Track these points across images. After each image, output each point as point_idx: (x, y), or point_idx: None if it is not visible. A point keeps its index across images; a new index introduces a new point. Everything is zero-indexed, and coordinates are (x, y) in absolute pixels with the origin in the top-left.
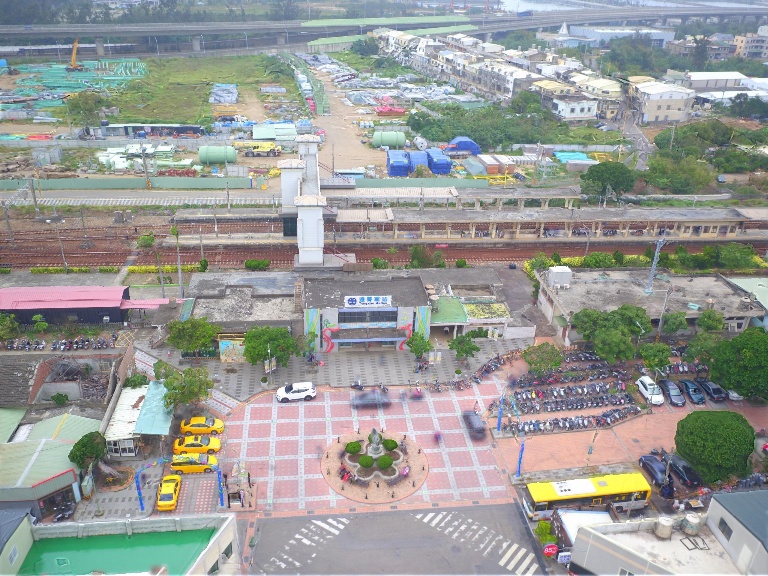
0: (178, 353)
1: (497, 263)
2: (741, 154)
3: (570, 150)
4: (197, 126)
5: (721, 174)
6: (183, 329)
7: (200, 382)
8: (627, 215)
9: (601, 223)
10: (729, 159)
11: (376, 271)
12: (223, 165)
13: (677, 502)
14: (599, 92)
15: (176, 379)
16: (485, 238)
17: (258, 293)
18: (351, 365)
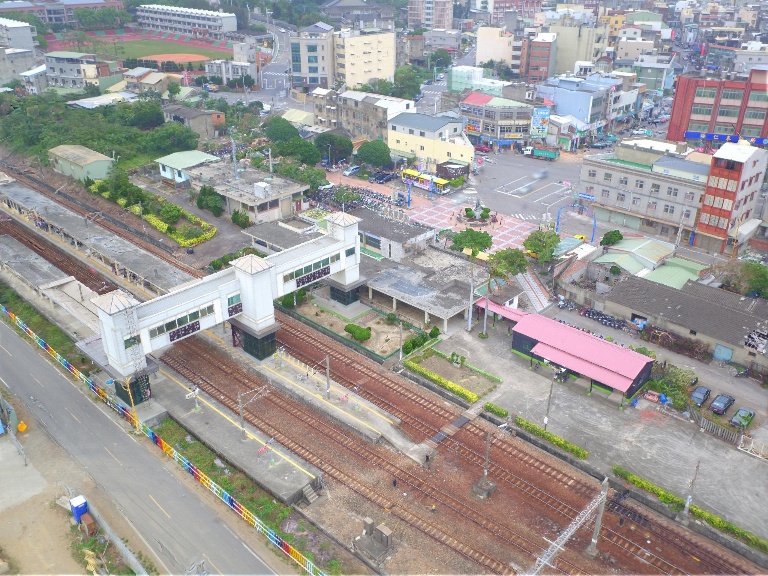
0: None
1: (183, 262)
2: None
3: None
4: None
5: None
6: None
7: None
8: (54, 211)
9: None
10: None
11: None
12: None
13: (398, 175)
14: None
15: (550, 232)
16: None
17: None
18: None
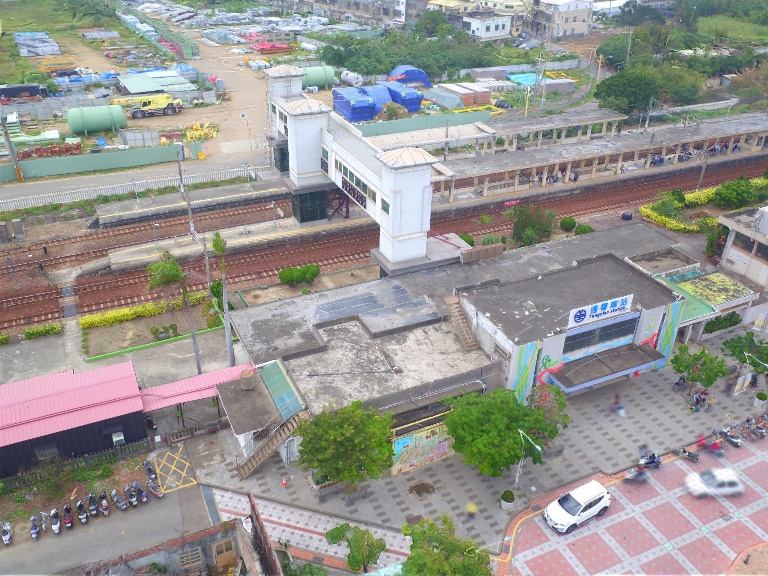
0: (298, 476)
1: (599, 215)
2: (702, 57)
3: (519, 71)
4: (34, 85)
5: (708, 79)
6: (342, 440)
7: (484, 563)
8: (703, 131)
9: (681, 145)
10: (690, 64)
11: (503, 255)
12: (111, 133)
13: None
14: (502, 7)
15: (441, 575)
16: (557, 184)
17: (369, 327)
18: (596, 423)
